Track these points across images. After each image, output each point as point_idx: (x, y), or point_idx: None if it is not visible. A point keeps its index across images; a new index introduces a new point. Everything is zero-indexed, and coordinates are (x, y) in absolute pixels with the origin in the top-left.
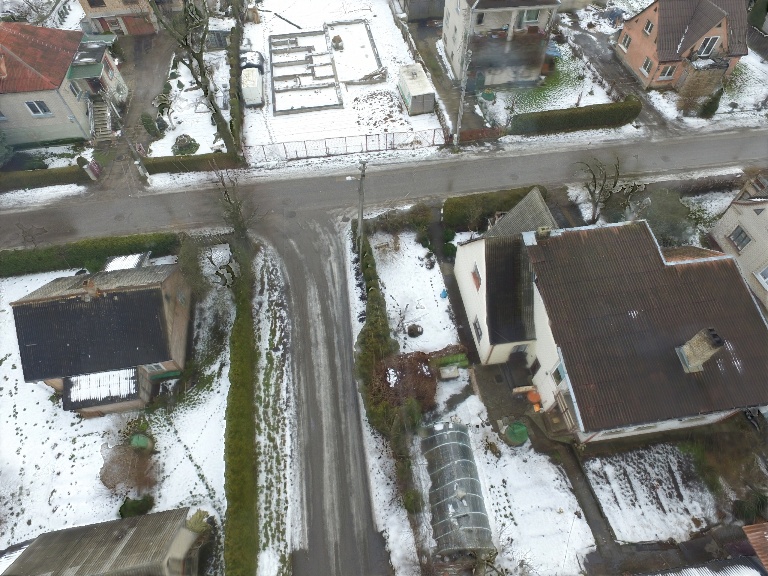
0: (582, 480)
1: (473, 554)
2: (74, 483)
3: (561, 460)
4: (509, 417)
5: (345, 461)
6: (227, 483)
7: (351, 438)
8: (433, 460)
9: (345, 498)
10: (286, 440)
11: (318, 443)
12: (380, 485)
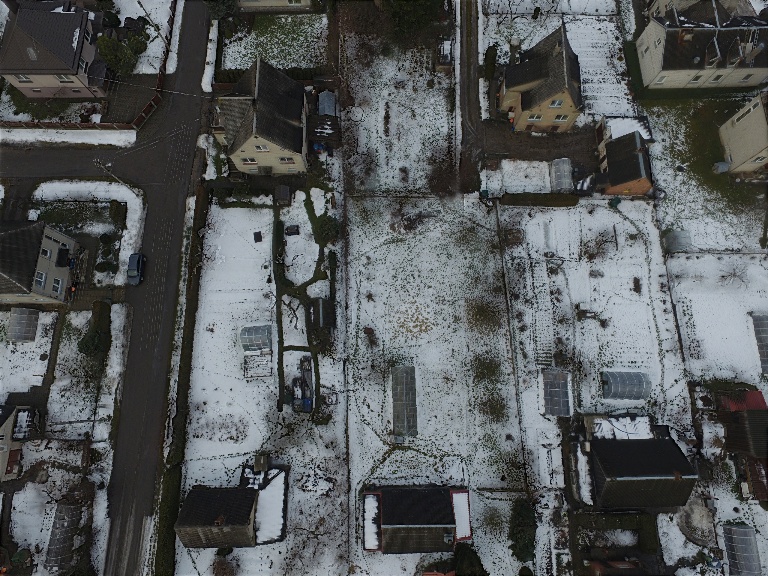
0: (3, 525)
1: (67, 501)
2: (260, 571)
3: (8, 537)
4: (22, 567)
5: (117, 557)
6: (163, 557)
7: (110, 570)
8: (67, 550)
9: (121, 537)
10: (146, 575)
11: (129, 571)
12: (102, 541)
